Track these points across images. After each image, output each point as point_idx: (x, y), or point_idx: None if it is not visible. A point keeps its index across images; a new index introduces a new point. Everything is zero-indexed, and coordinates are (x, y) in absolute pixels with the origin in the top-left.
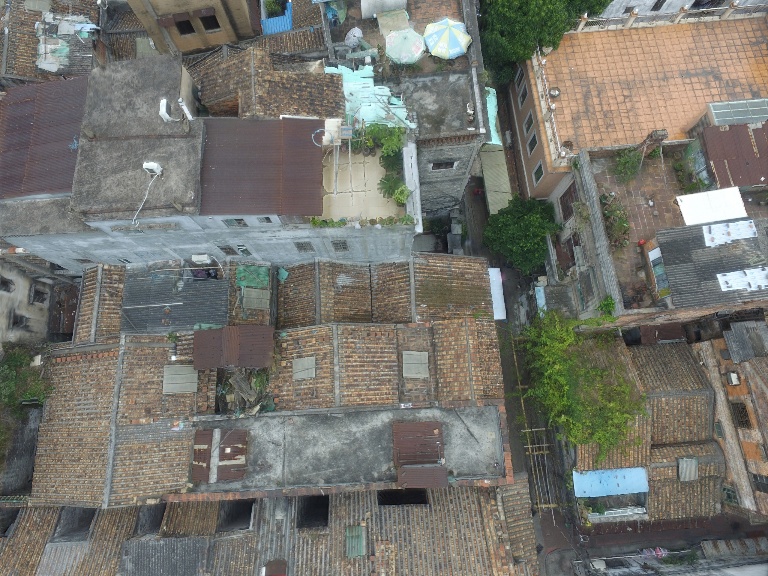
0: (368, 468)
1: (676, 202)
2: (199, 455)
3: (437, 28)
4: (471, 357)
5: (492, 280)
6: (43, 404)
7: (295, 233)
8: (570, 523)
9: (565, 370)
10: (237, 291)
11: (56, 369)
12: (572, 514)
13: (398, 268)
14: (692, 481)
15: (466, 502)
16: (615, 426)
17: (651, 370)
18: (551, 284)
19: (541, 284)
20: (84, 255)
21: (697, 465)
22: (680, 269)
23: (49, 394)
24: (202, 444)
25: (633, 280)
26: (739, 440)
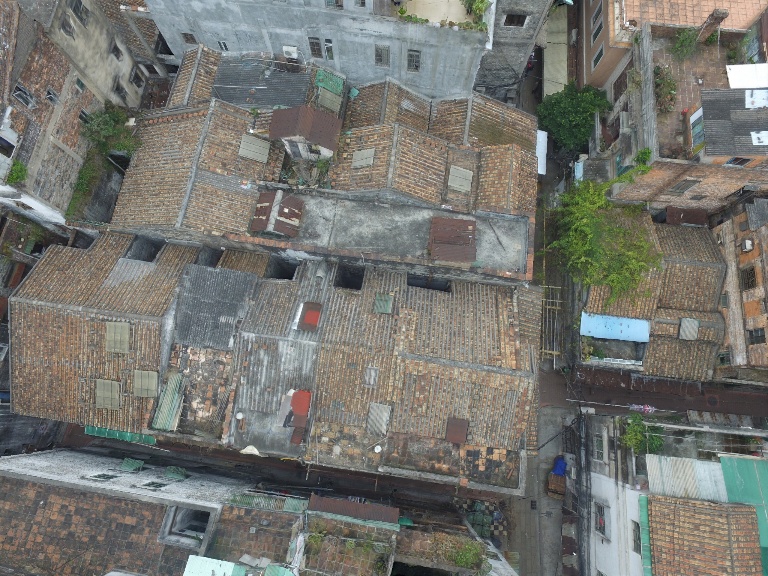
0: (404, 251)
1: (724, 85)
2: (260, 211)
3: None
4: (512, 175)
5: (538, 140)
6: (132, 155)
7: (381, 27)
8: (569, 368)
9: (592, 223)
10: (315, 88)
11: (147, 129)
12: (573, 354)
13: (457, 104)
14: (690, 344)
15: (485, 297)
16: (629, 272)
17: (671, 242)
18: (591, 158)
19: (581, 159)
20: (192, 27)
21: (698, 327)
22: (718, 124)
23: (138, 148)
24: (264, 202)
25: (671, 142)
26: (742, 303)
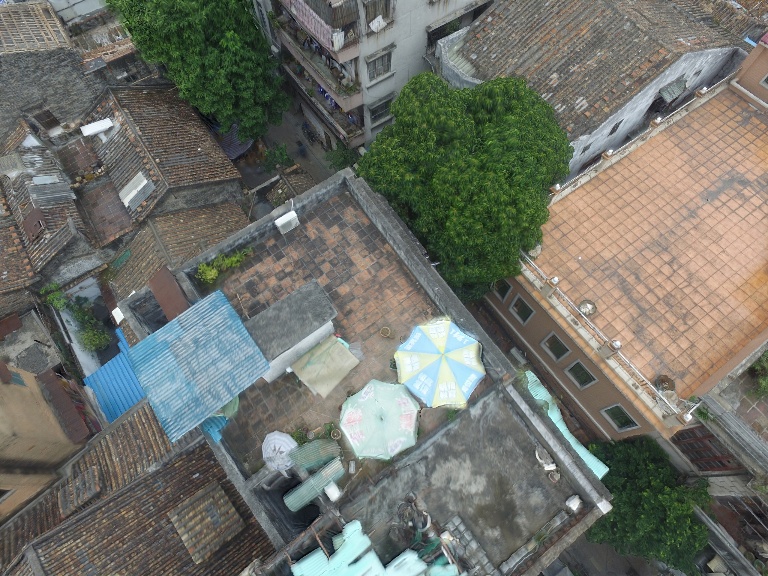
0: None
1: None
2: None
3: (417, 359)
4: None
5: None
6: None
7: None
8: None
9: None
10: None
11: None
12: None
13: None
14: None
15: None
16: None
17: None
18: None
19: None
20: None
21: None
22: None
23: None
24: None
25: None
26: None
